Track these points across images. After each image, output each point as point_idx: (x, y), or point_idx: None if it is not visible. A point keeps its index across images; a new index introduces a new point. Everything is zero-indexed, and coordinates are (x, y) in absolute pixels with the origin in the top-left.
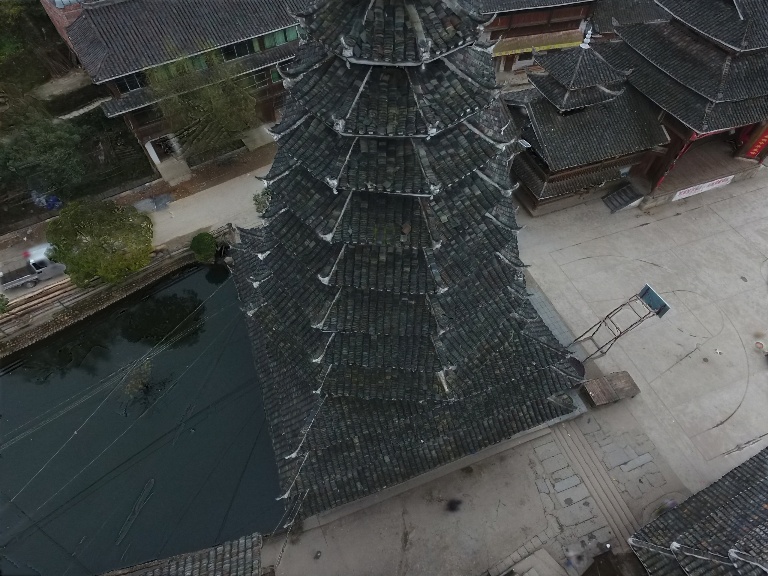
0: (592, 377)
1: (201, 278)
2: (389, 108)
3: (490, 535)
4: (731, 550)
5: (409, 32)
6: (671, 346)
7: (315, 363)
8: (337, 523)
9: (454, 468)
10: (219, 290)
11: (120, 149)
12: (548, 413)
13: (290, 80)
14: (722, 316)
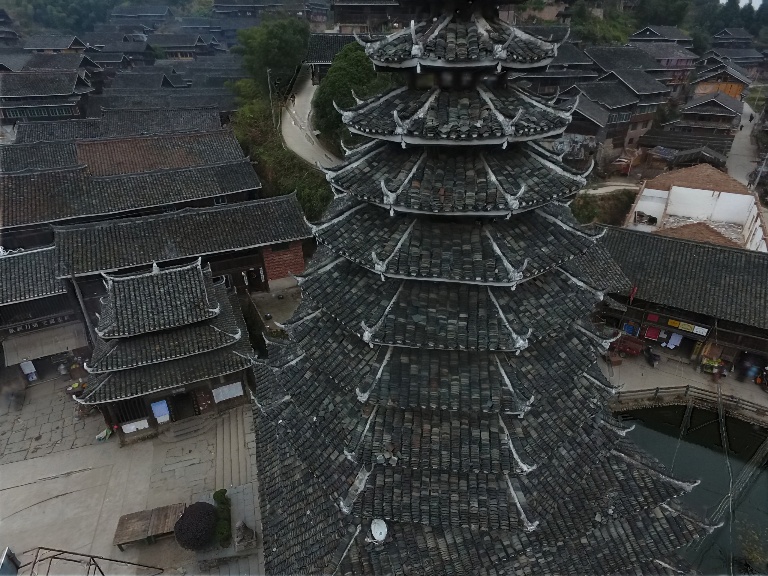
0: (156, 554)
1: None
2: None
3: None
4: None
5: None
6: None
7: None
8: None
9: None
10: None
11: None
12: None
13: None
14: None
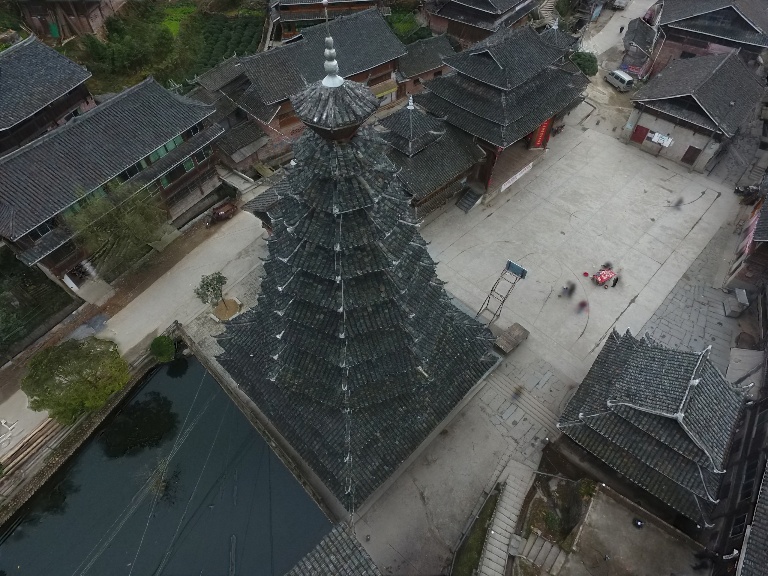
0: None
1: (163, 377)
2: (359, 228)
3: (476, 467)
4: (607, 402)
5: (363, 190)
6: (537, 295)
7: (338, 393)
8: (371, 510)
9: (435, 435)
10: (185, 381)
11: (33, 289)
12: (483, 369)
13: (292, 227)
14: (559, 263)
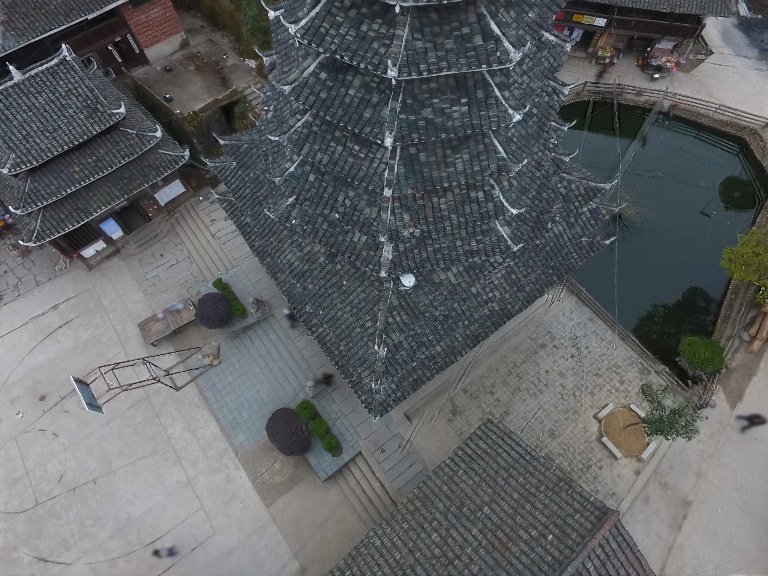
0: (186, 340)
1: None
2: None
3: None
4: None
5: None
6: None
7: None
8: None
9: None
10: None
11: None
12: None
13: None
14: None
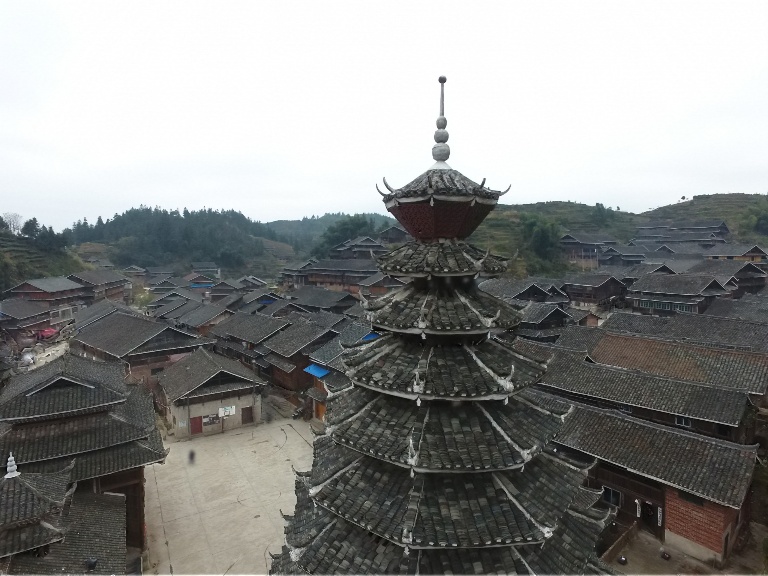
0: None
1: None
2: None
3: None
4: None
5: None
6: None
7: None
8: None
9: None
10: None
11: None
12: None
13: None
14: None
